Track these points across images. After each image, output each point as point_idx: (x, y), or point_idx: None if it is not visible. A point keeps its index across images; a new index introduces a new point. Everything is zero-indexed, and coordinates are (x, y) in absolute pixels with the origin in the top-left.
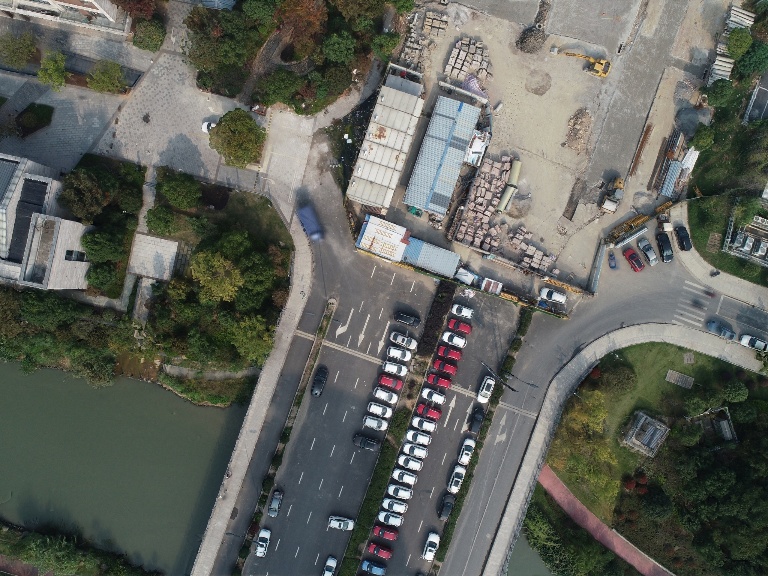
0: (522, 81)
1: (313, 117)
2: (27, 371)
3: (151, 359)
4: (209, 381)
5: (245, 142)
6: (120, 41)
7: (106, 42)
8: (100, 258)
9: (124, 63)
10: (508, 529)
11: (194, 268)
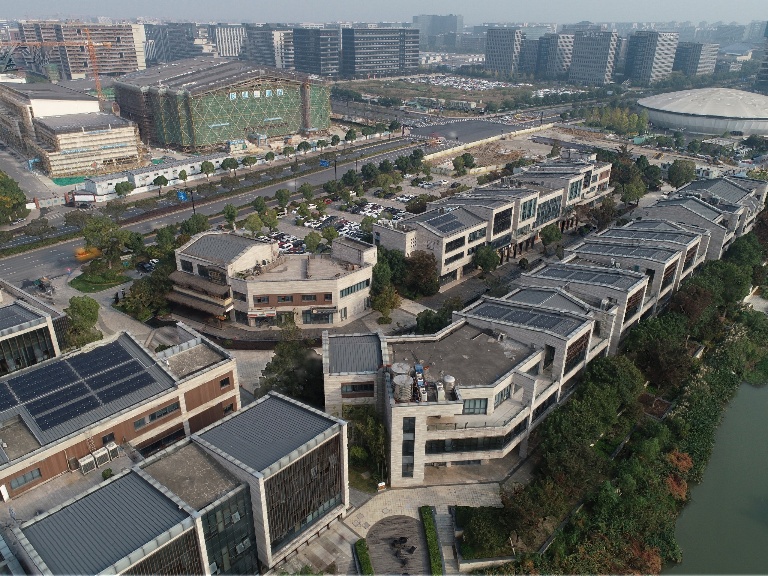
0: None
1: (664, 185)
2: None
3: None
4: None
5: None
6: None
7: None
8: None
9: None
10: None
11: None
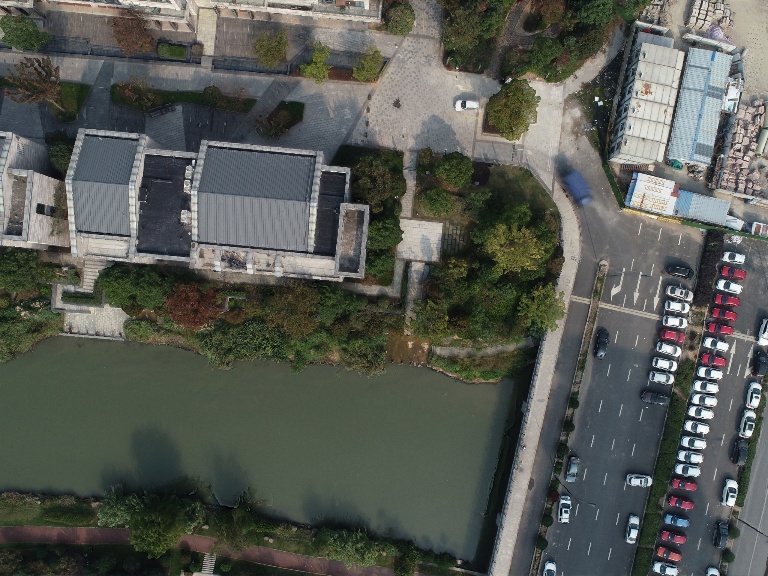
0: (763, 25)
1: (562, 84)
2: (298, 369)
3: (438, 340)
4: (482, 357)
5: (532, 111)
6: (362, 30)
7: (348, 33)
8: (384, 245)
9: (369, 51)
10: None
11: (490, 242)
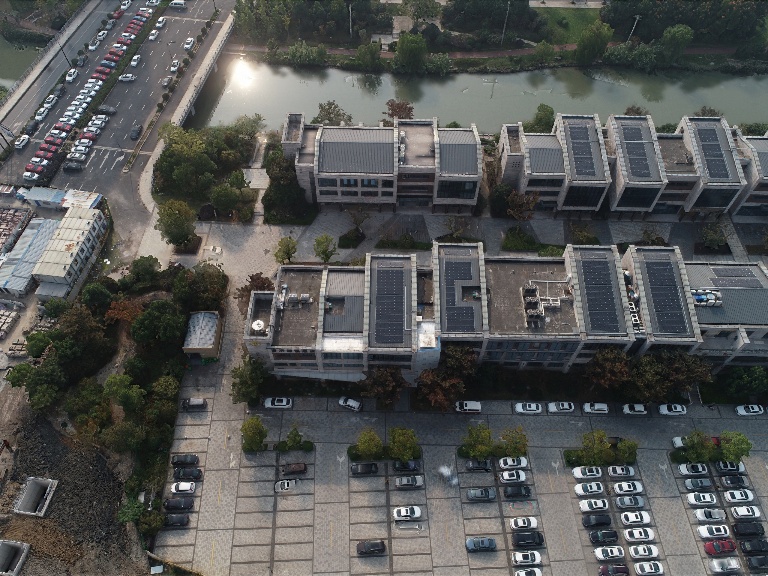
0: None
1: None
2: None
3: None
4: None
5: None
6: None
7: None
8: None
9: None
10: (22, 88)
11: None
